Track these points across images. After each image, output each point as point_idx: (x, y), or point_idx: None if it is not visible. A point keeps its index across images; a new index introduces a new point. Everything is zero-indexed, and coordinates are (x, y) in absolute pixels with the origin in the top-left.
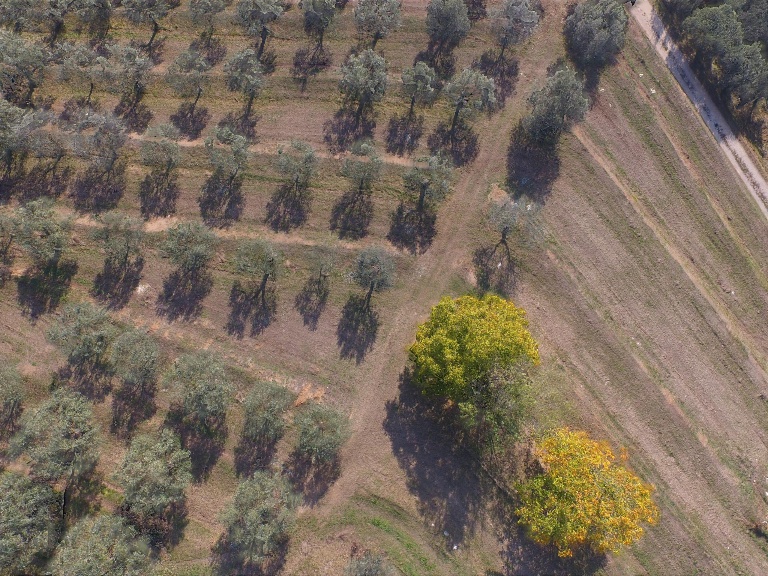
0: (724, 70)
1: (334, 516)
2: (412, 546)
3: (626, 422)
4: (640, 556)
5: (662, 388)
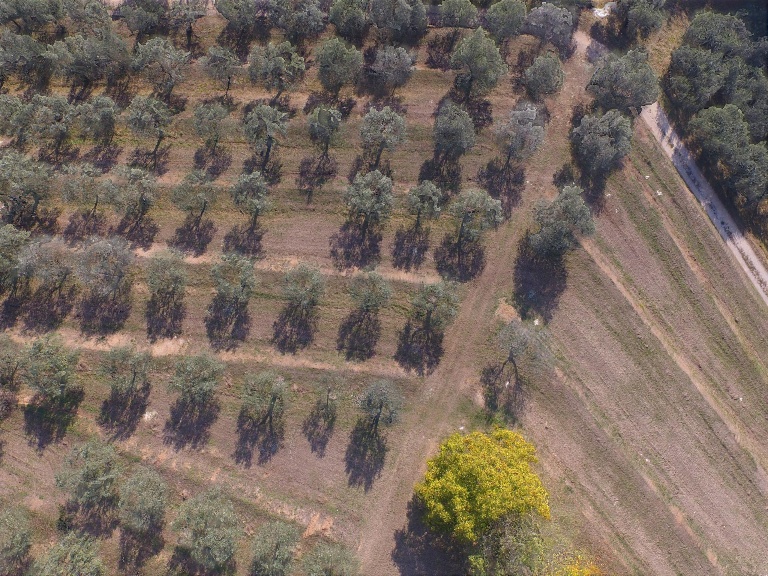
0: (730, 171)
1: None
2: None
3: (635, 543)
4: None
5: (671, 506)
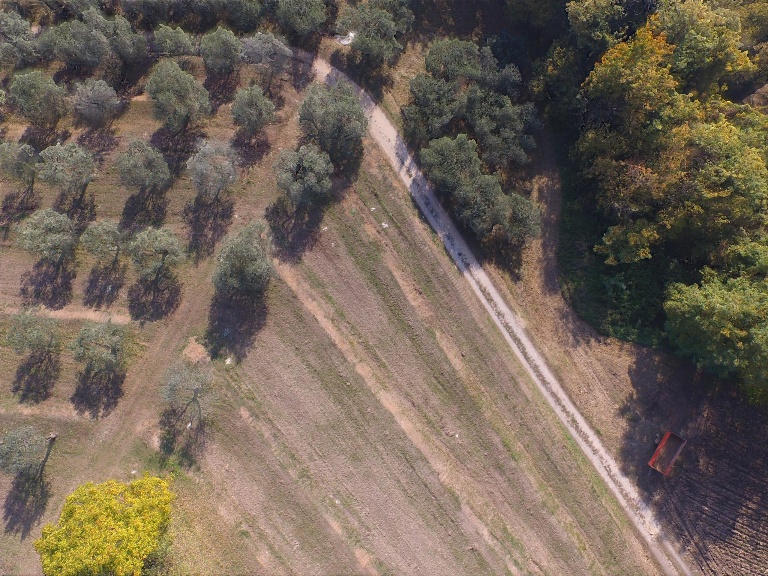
0: None
1: None
2: None
3: None
4: None
5: (357, 549)
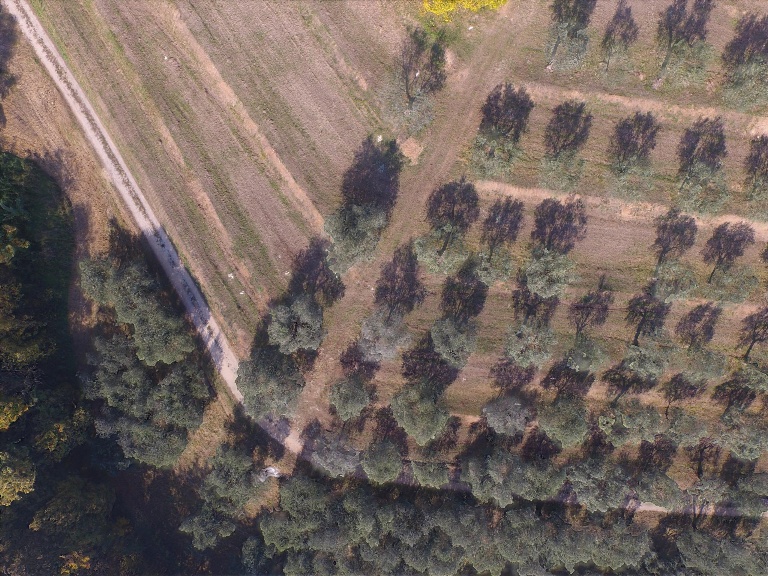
0: None
1: None
2: None
3: None
4: None
5: None
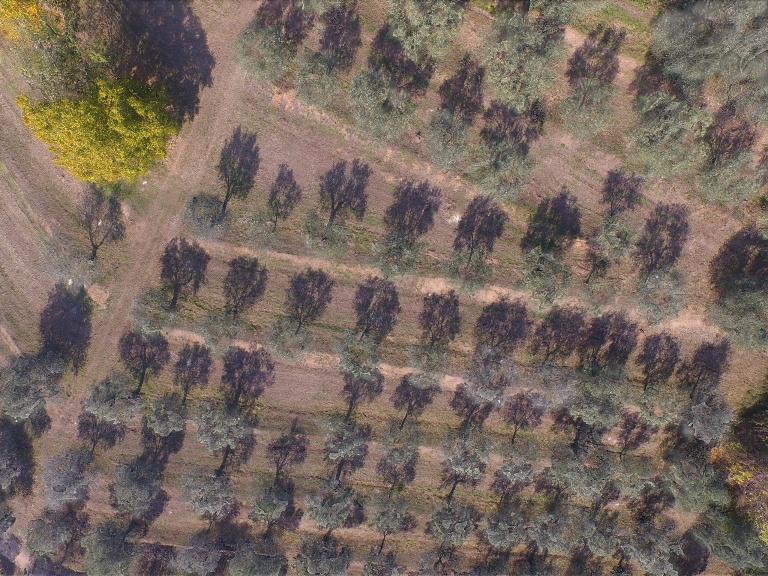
0: None
1: None
2: None
3: None
4: None
5: None
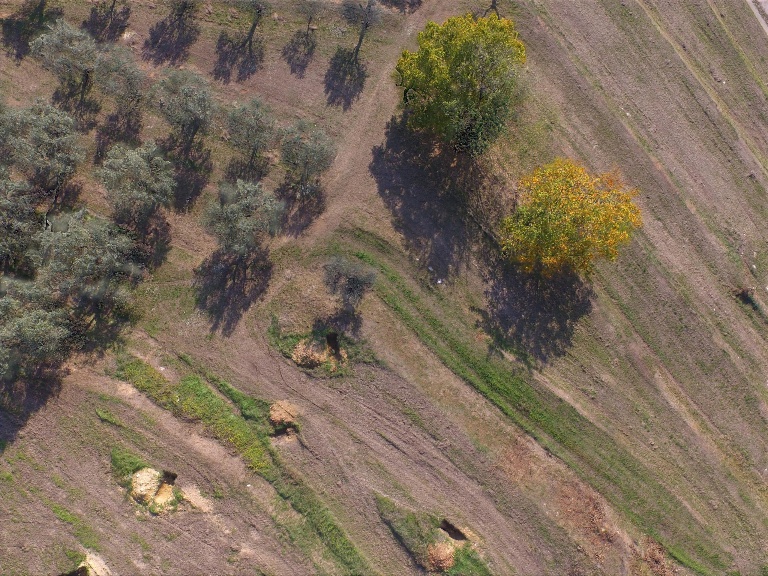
0: None
1: (318, 247)
2: (396, 279)
3: (614, 185)
4: (626, 310)
5: (651, 156)
